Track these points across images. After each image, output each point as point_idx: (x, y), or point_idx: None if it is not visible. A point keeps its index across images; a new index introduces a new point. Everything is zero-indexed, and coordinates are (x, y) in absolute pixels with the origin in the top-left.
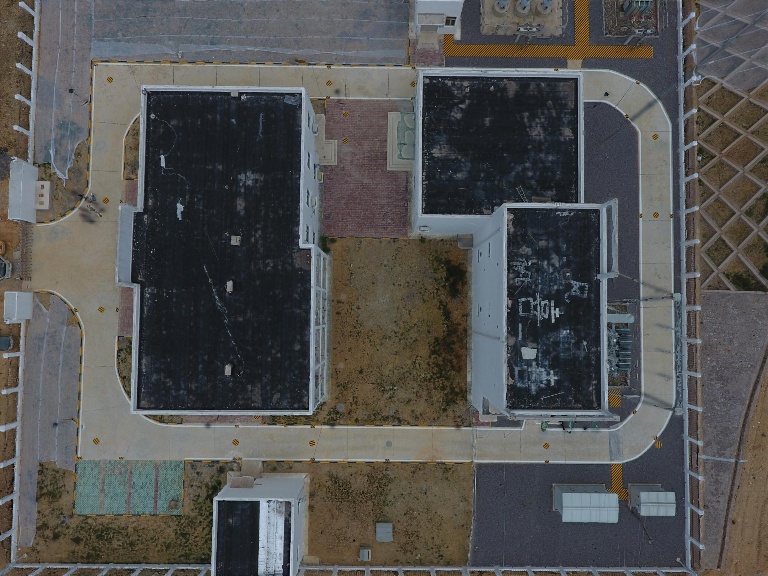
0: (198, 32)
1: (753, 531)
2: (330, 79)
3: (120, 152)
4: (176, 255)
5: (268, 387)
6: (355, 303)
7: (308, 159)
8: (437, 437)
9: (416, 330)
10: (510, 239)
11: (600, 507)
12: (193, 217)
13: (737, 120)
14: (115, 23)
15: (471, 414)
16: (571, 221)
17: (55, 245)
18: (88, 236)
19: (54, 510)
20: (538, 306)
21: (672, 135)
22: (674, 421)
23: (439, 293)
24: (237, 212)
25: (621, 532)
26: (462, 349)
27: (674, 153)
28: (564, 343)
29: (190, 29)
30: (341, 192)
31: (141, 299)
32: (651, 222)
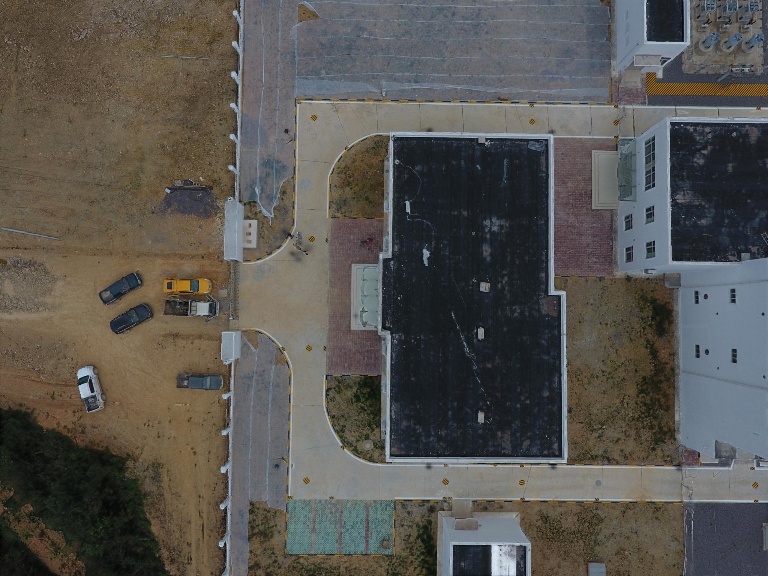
0: (401, 70)
1: None
2: (533, 117)
3: (325, 190)
4: (423, 301)
5: (518, 434)
6: None
7: None
8: (646, 476)
9: (624, 369)
10: None
11: None
12: (440, 263)
13: None
14: (318, 61)
15: (680, 453)
16: None
17: (262, 284)
18: (294, 275)
19: (266, 550)
20: None
21: None
22: None
23: (646, 332)
24: (483, 258)
25: None
26: (670, 388)
27: None
28: None
29: (393, 67)
30: None
31: (391, 346)
32: None
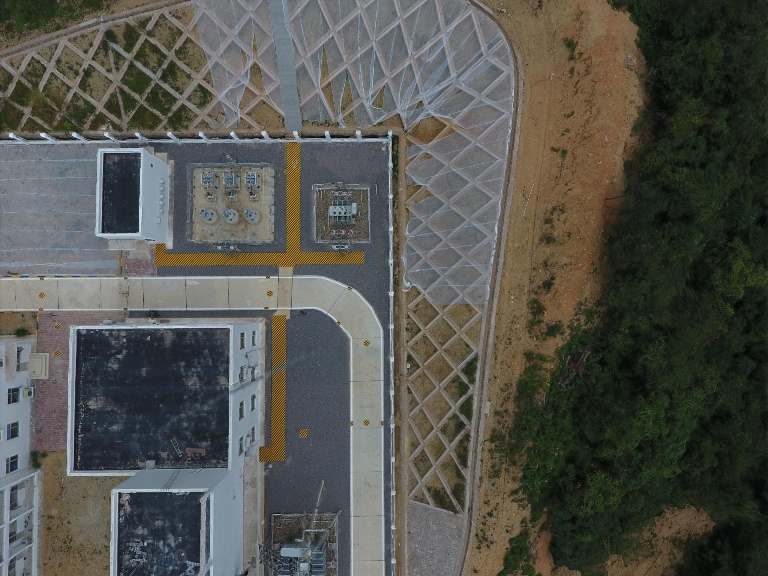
0: None
1: None
2: (43, 291)
3: None
4: None
5: None
6: (66, 518)
7: None
8: None
9: None
10: (126, 519)
11: None
12: None
13: (435, 334)
14: None
15: None
16: (187, 500)
17: None
18: None
19: None
20: None
21: (383, 341)
22: None
23: None
24: None
25: None
26: None
27: (385, 359)
28: None
29: None
30: (53, 405)
31: None
32: (361, 430)
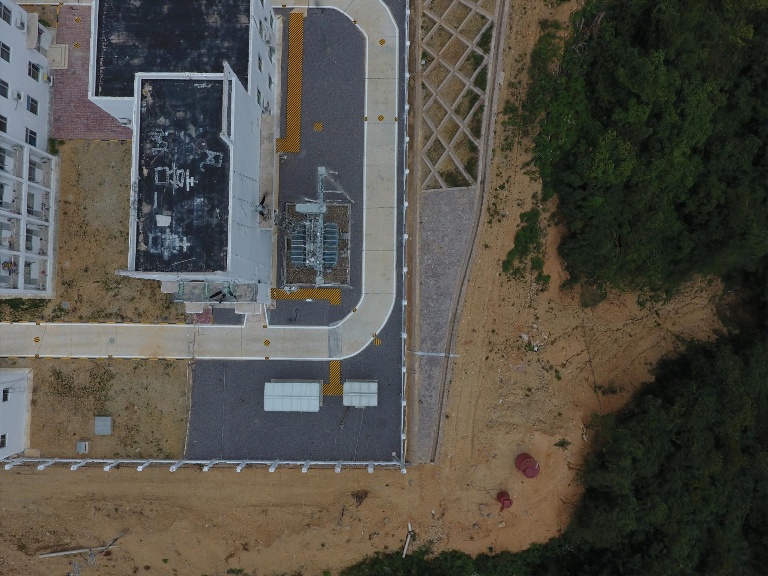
0: None
1: (467, 426)
2: None
3: None
4: None
5: None
6: (82, 203)
7: (7, 52)
8: (160, 334)
9: None
10: (148, 110)
11: (301, 396)
12: None
13: (451, 21)
14: None
15: None
16: (208, 93)
17: None
18: None
19: None
20: (174, 175)
21: (399, 40)
22: (393, 319)
23: None
24: None
25: (338, 427)
26: None
27: (400, 58)
28: (198, 211)
29: None
30: (71, 95)
31: None
32: (376, 125)
